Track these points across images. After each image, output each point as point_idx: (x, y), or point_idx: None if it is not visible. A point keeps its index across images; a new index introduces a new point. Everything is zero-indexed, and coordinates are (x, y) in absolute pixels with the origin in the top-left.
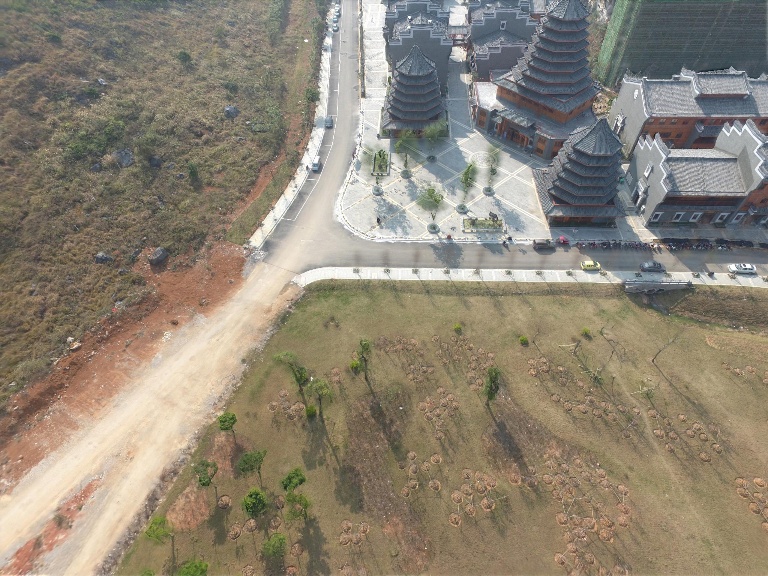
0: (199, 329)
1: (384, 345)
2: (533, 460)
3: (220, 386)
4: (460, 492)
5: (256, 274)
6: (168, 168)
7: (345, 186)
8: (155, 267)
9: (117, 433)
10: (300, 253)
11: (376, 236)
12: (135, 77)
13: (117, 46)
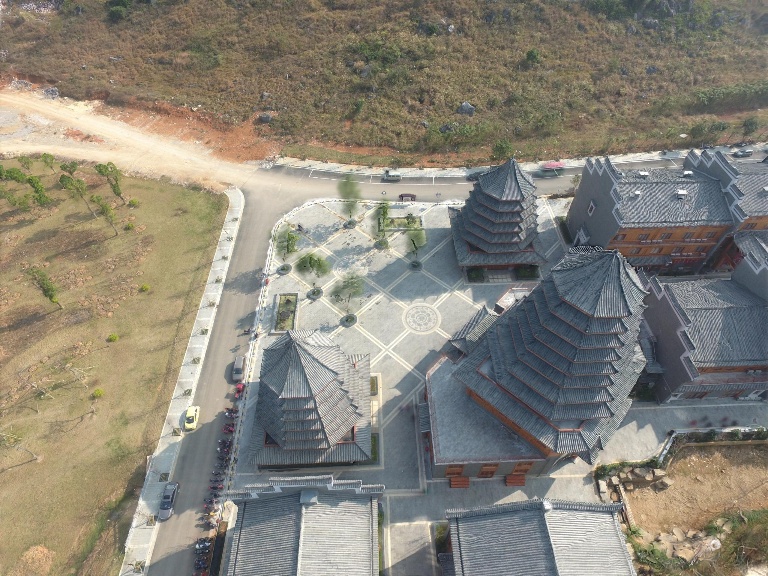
0: (199, 153)
1: (145, 241)
2: (3, 338)
3: (147, 171)
4: (6, 292)
5: (245, 167)
6: (367, 96)
7: (359, 201)
8: (258, 120)
9: (130, 141)
10: (265, 185)
11: (278, 228)
12: (475, 41)
13: (506, 16)
